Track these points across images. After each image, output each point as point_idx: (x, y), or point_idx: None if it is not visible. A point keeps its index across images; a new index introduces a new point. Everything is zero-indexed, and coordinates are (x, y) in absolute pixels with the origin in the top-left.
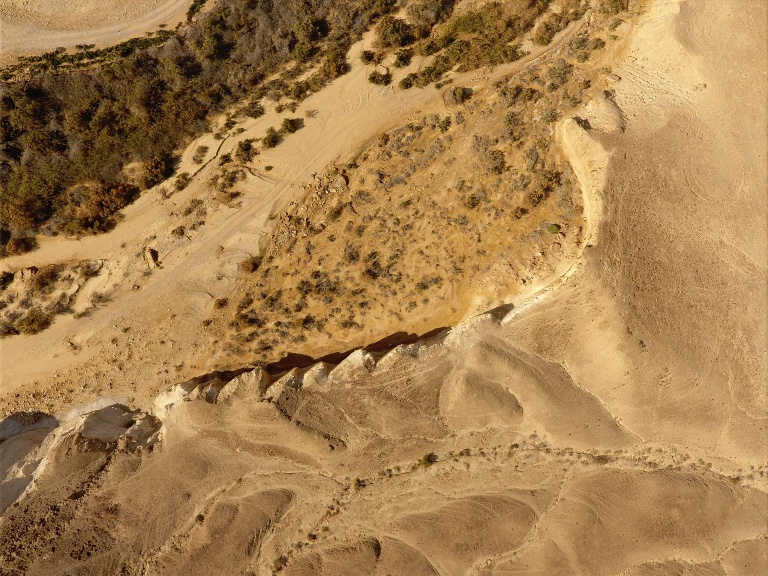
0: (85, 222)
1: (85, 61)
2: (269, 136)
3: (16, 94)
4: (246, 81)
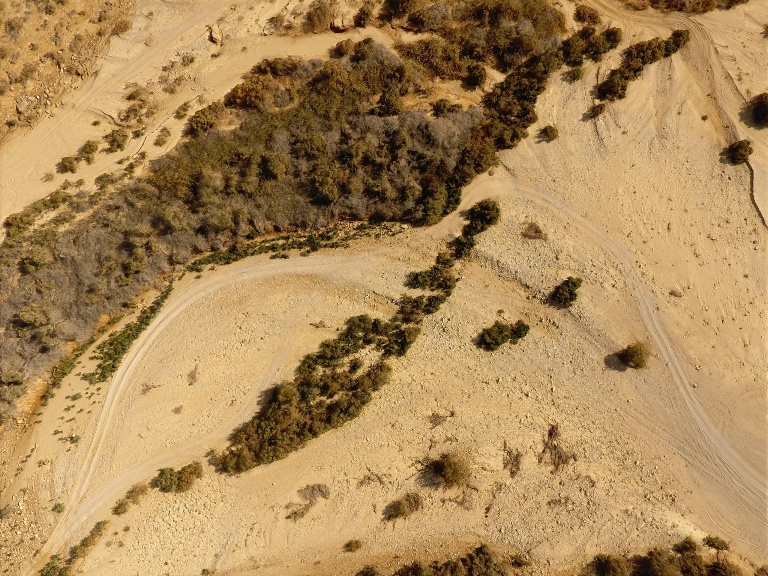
0: (273, 66)
1: (281, 242)
2: (86, 150)
3: (332, 192)
4: (105, 207)
